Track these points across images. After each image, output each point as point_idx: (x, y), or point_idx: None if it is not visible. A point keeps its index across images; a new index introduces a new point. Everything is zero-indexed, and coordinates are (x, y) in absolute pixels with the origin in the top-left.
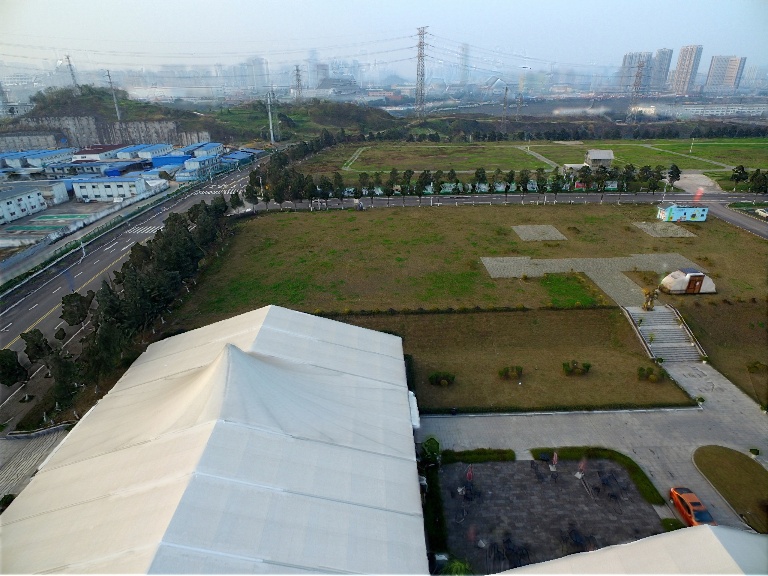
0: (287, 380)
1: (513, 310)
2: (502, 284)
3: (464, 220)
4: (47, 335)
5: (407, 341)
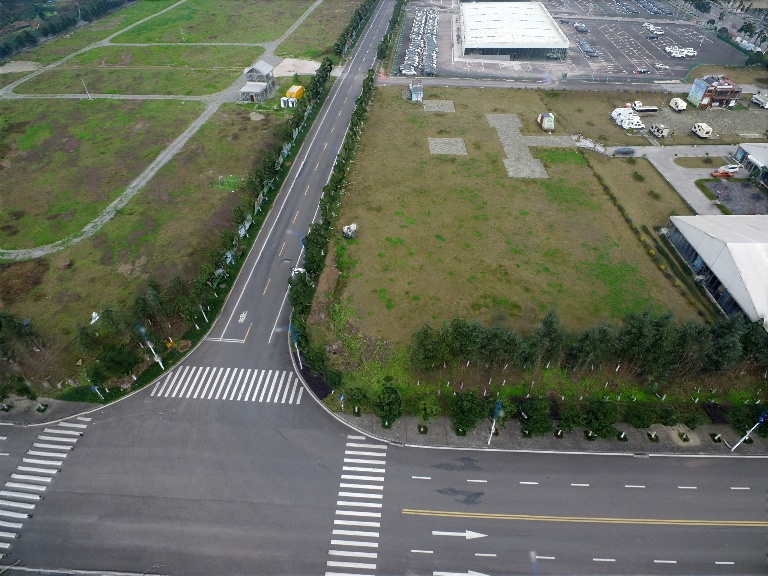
0: None
1: None
2: (558, 176)
3: (411, 172)
4: (764, 489)
5: None
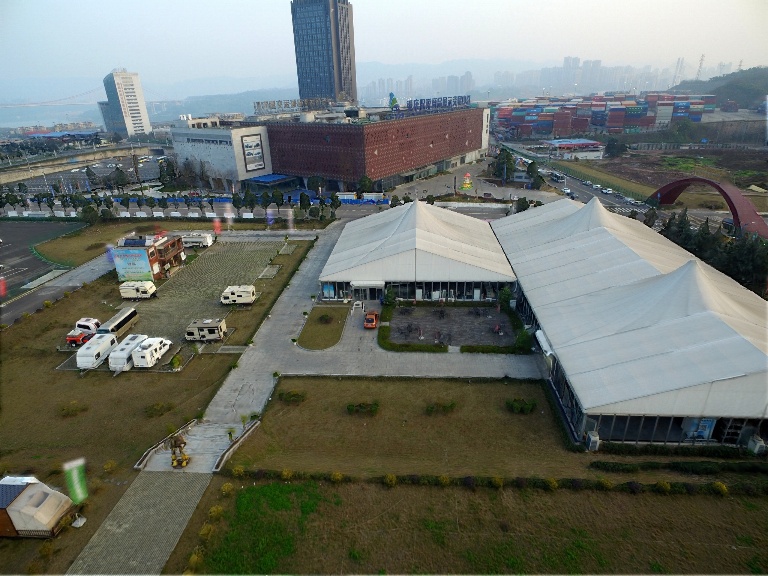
0: (647, 296)
1: (405, 476)
2: None
3: None
4: None
5: (583, 466)
